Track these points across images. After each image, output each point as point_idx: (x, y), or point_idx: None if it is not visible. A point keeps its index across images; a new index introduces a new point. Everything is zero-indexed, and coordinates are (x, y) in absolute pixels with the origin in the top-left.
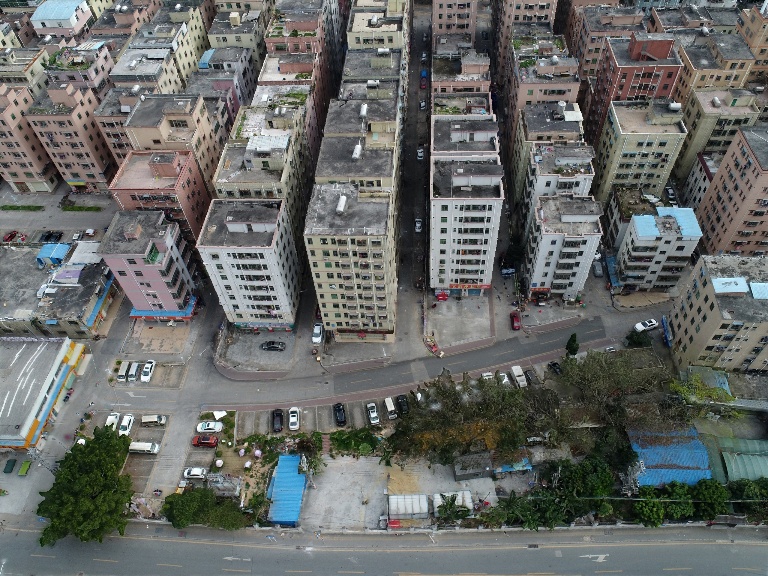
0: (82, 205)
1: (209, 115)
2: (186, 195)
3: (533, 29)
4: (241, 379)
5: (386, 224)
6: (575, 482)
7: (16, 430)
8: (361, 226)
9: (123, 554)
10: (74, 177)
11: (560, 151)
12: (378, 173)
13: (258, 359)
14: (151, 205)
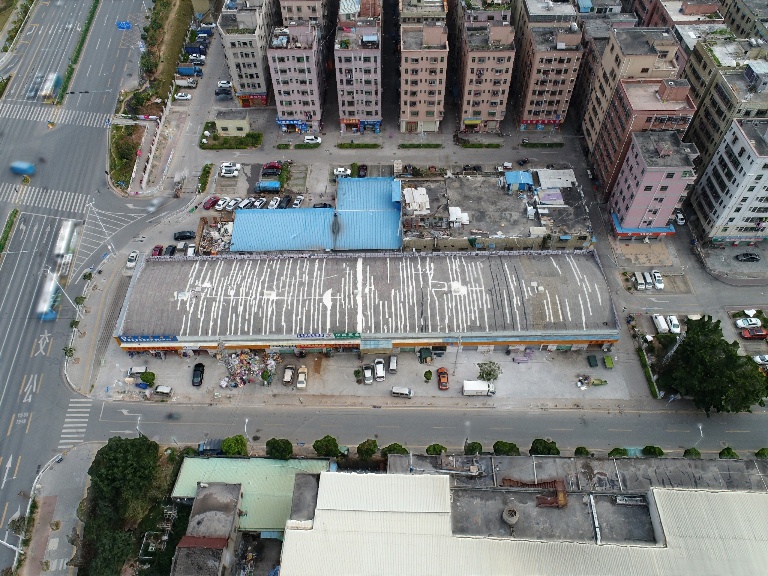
0: (478, 142)
1: None
2: None
3: None
4: (741, 285)
5: None
6: None
7: (605, 326)
8: None
9: (750, 426)
10: (474, 115)
11: None
12: None
13: (740, 269)
14: (658, 127)
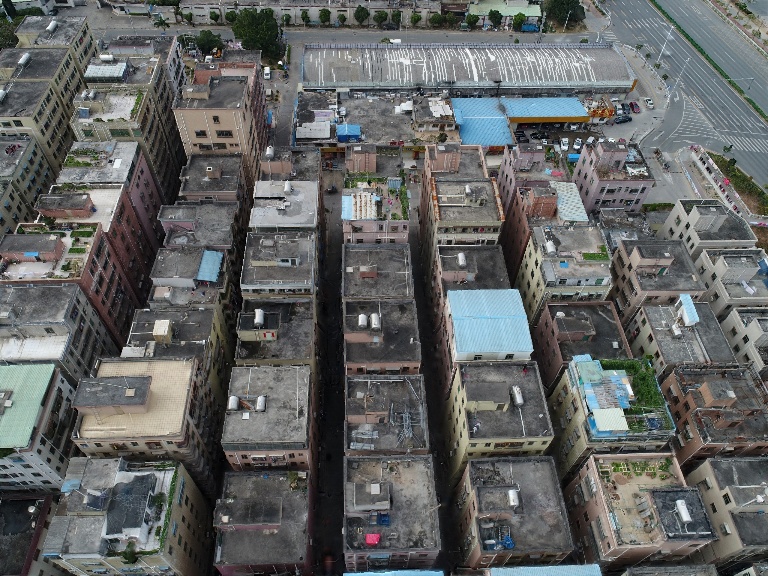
0: None
1: (195, 174)
2: None
3: None
4: None
5: (24, 21)
6: None
7: (312, 49)
8: (43, 21)
9: None
10: None
11: None
12: (13, 51)
13: None
14: None
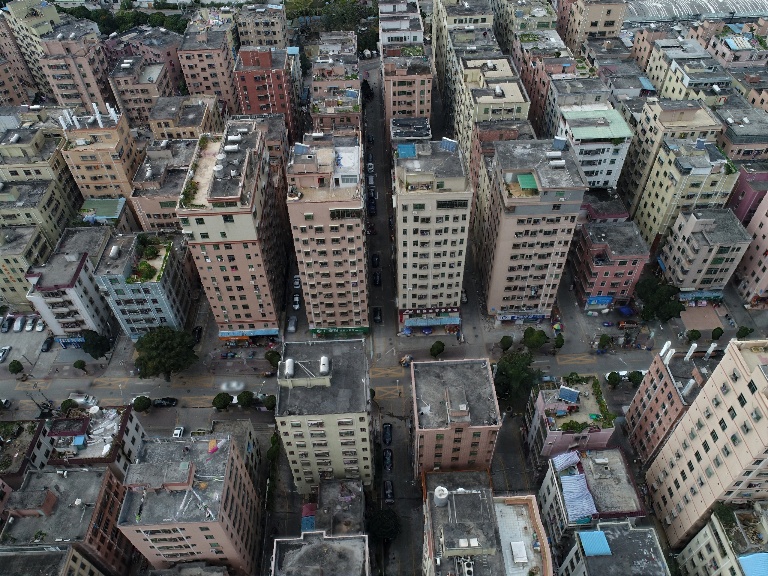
0: None
1: (594, 48)
2: (561, 9)
3: (336, 130)
4: None
5: None
6: (352, 7)
7: None
8: None
9: None
10: None
11: (339, 42)
12: None
13: None
14: None
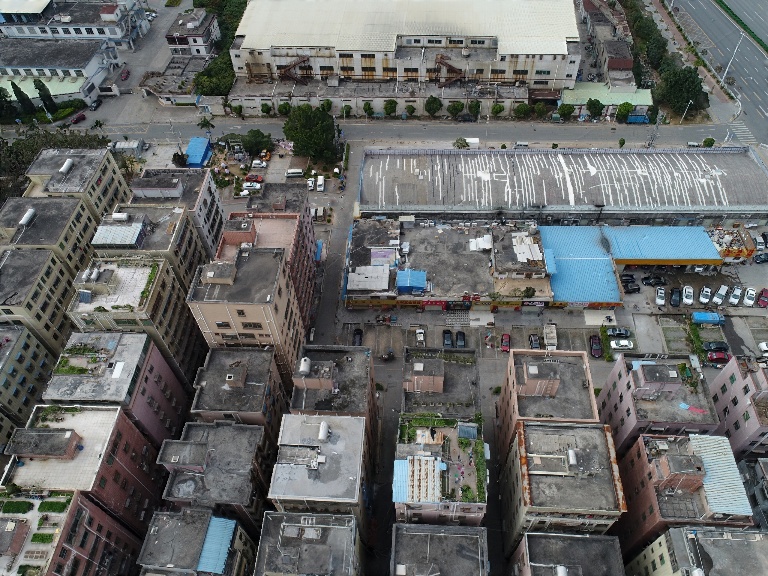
0: None
1: (213, 378)
2: None
3: None
4: None
5: (38, 157)
6: None
7: (373, 157)
8: (59, 156)
9: None
10: None
11: None
12: (19, 202)
13: None
14: None
